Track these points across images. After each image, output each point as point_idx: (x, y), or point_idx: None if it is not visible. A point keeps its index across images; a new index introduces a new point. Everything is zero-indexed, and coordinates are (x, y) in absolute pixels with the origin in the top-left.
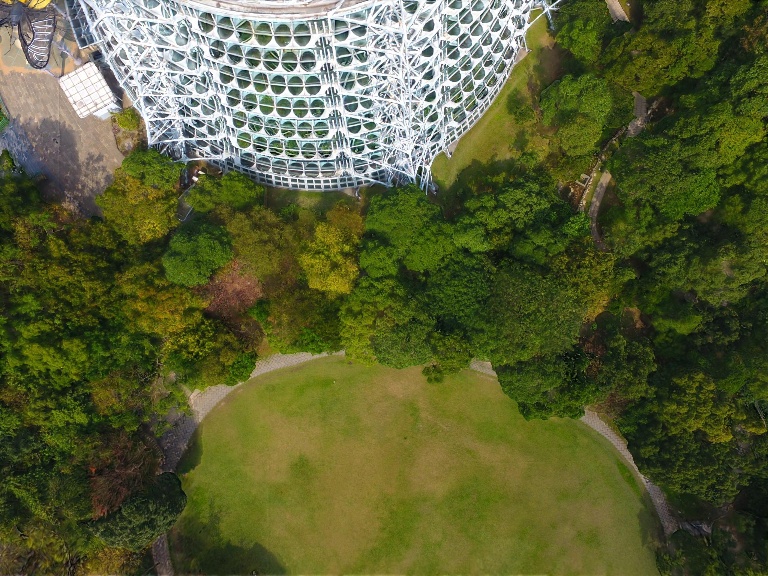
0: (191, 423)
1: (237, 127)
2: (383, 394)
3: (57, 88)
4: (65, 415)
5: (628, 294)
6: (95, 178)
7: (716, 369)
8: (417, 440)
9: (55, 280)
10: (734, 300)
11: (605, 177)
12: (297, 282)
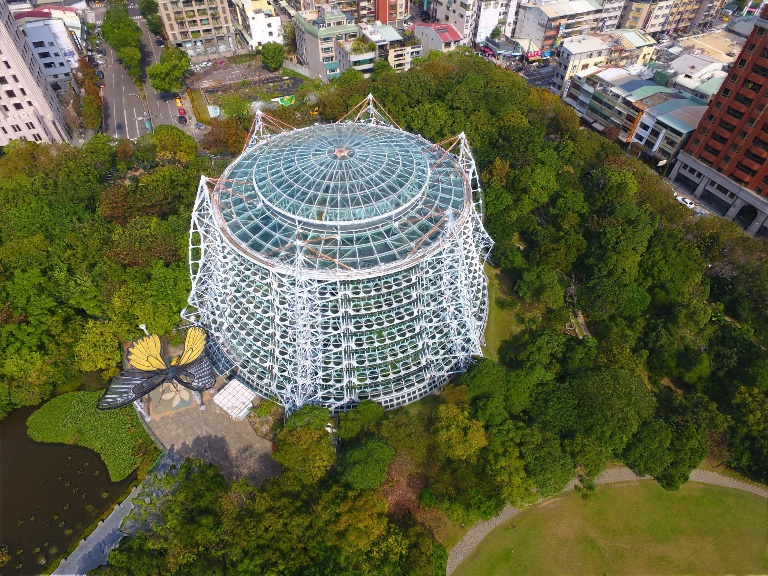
0: None
1: (361, 364)
2: (557, 541)
3: (200, 414)
4: None
5: (654, 368)
6: (245, 466)
7: (747, 381)
8: (615, 571)
9: (265, 533)
10: (711, 335)
11: (580, 319)
12: (442, 464)
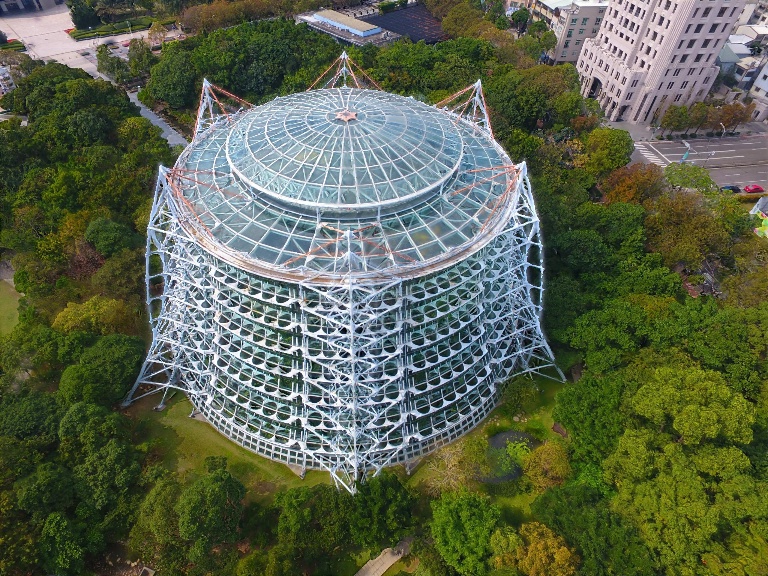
0: (5, 275)
1: None
2: None
3: None
4: (21, 195)
5: None
6: None
7: None
8: None
9: None
10: None
11: None
12: None
